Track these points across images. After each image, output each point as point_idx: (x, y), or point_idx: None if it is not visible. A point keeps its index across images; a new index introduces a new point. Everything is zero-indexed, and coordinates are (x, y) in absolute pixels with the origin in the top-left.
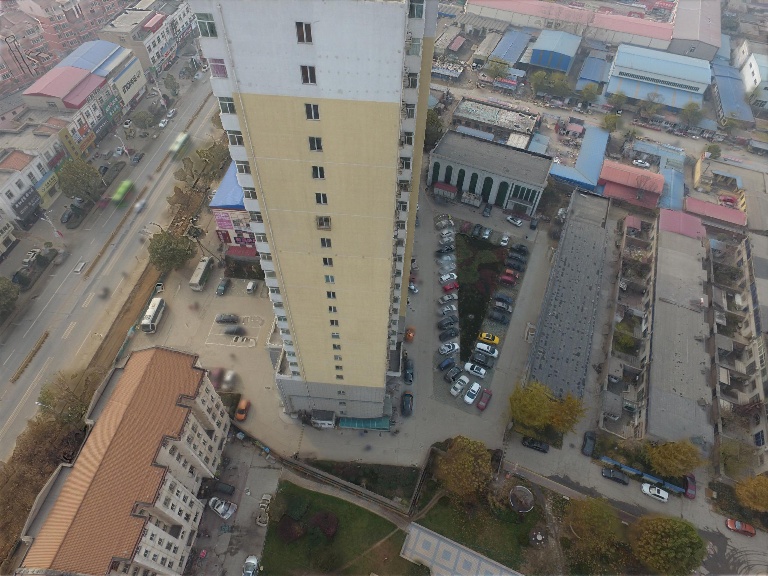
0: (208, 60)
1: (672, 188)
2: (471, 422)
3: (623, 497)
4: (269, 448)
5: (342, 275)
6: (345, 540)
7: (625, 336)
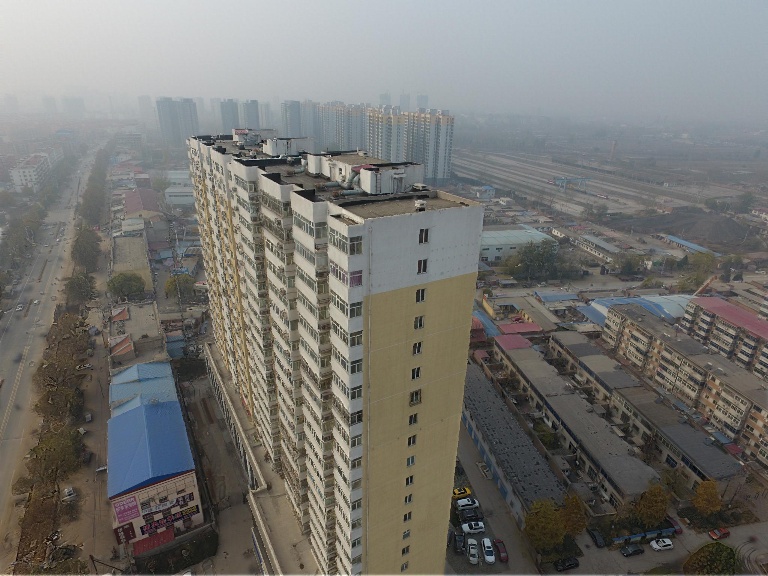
0: (349, 274)
1: (485, 323)
2: None
3: (650, 564)
4: None
5: (422, 450)
6: None
7: (547, 435)
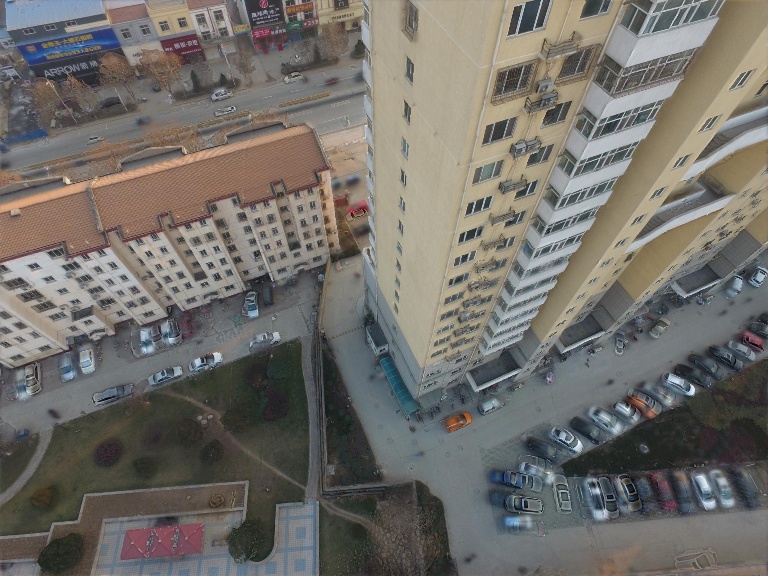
0: None
1: None
2: (482, 522)
3: None
4: (320, 308)
5: (415, 151)
6: (269, 434)
7: None
